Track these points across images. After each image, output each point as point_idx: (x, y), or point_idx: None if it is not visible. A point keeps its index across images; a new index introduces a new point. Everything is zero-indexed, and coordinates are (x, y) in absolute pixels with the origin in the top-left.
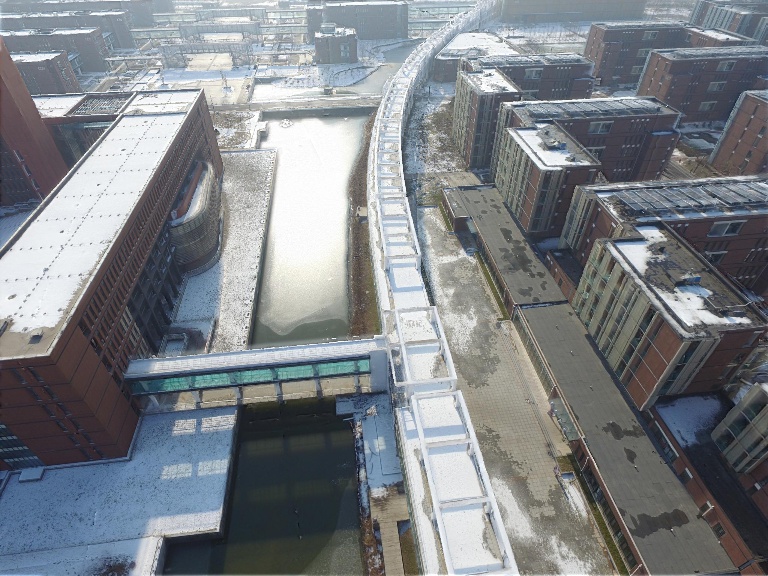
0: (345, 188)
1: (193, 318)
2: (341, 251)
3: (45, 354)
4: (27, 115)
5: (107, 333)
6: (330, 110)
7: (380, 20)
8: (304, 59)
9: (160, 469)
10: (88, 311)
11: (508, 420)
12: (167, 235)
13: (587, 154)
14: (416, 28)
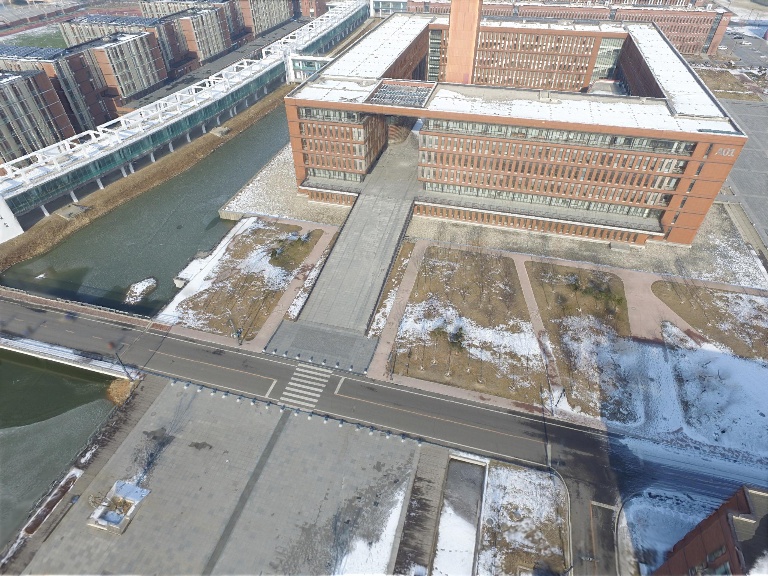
0: (204, 161)
1: None
2: (261, 122)
3: None
4: None
5: None
6: None
7: None
8: None
9: None
10: None
11: None
12: None
13: None
14: None
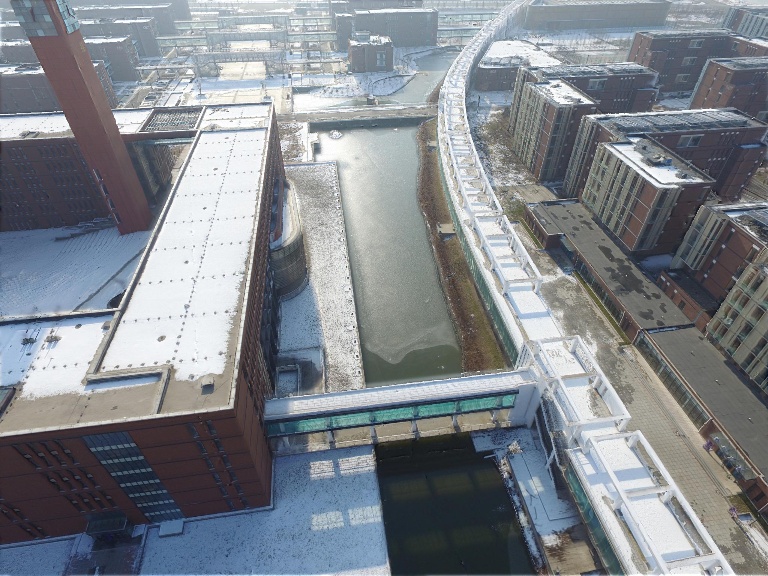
0: (415, 203)
1: (298, 347)
2: (430, 271)
3: (229, 407)
4: (110, 133)
5: (254, 374)
6: (378, 120)
7: (409, 28)
8: (338, 67)
9: (309, 518)
10: (245, 353)
11: (663, 455)
12: (269, 259)
13: (696, 170)
14: (445, 35)
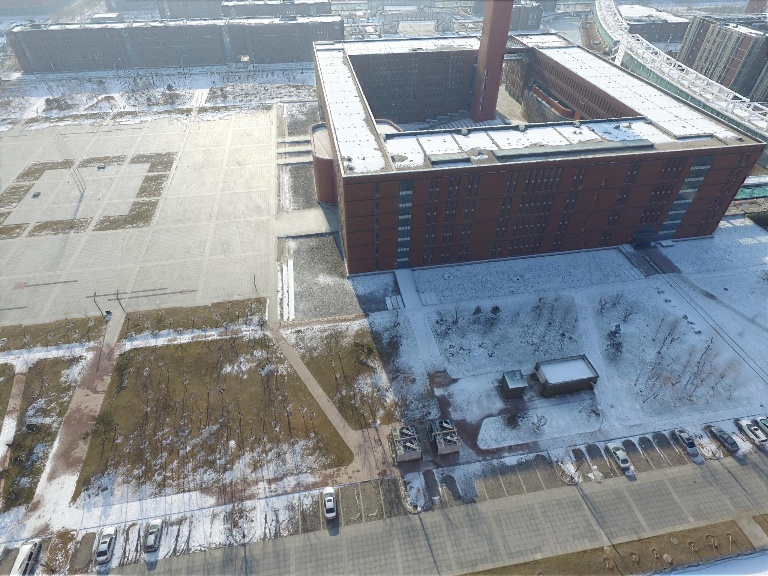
0: None
1: None
2: None
3: None
4: None
5: None
6: None
7: None
8: None
9: (737, 240)
10: None
11: None
12: None
13: None
14: (562, 3)
